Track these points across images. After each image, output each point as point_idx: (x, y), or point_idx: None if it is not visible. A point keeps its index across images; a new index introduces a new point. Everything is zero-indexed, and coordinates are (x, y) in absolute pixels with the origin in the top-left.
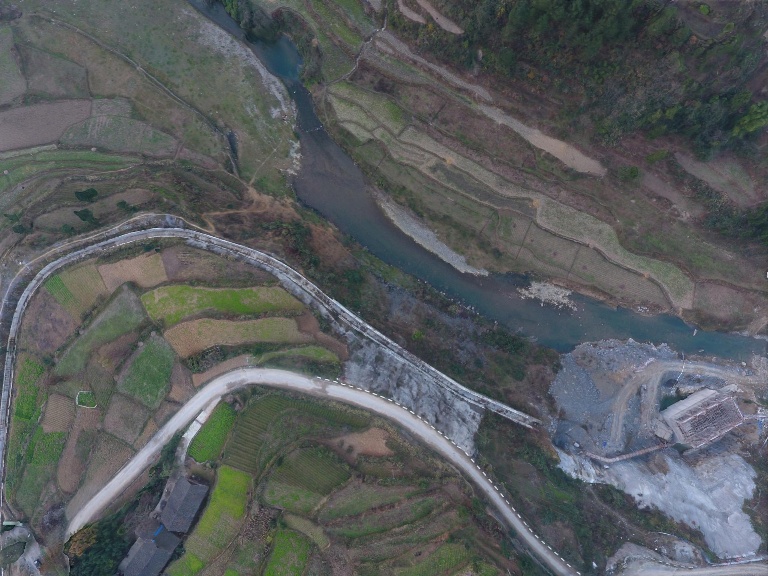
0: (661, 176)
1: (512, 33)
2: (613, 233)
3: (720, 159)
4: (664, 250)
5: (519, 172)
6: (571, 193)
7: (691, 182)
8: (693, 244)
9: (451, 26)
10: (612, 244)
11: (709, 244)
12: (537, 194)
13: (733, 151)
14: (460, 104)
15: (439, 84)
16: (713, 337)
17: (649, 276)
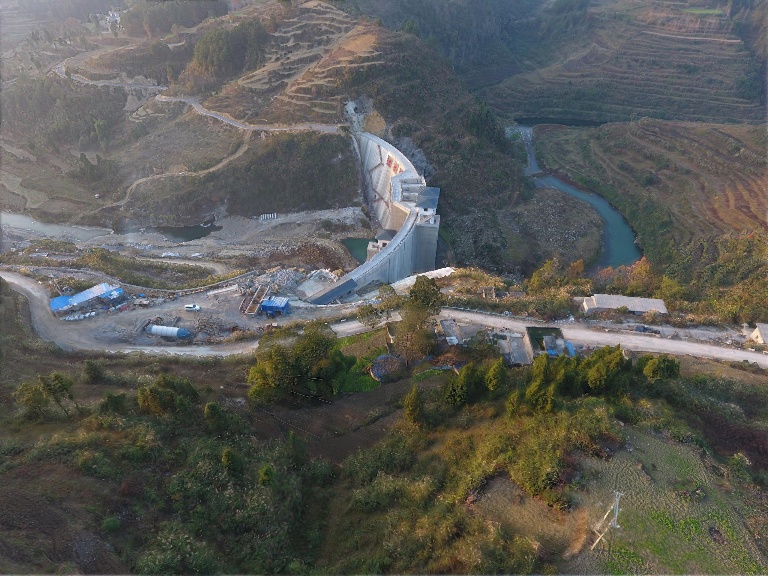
0: None
1: (11, 107)
2: None
3: (93, 151)
4: None
5: None
6: None
7: (71, 158)
8: (63, 185)
9: None
10: (15, 184)
11: (71, 185)
12: None
13: (99, 147)
14: None
15: None
16: (45, 226)
17: (23, 195)
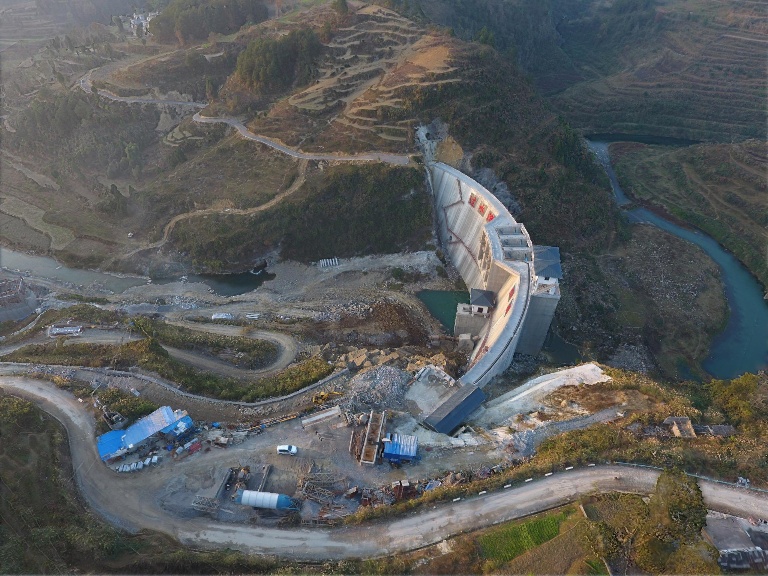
0: (88, 188)
1: (31, 126)
2: (43, 214)
3: (124, 179)
4: (68, 221)
5: (10, 188)
6: (33, 197)
7: None
8: (91, 220)
9: (12, 130)
10: None
11: (100, 220)
12: (12, 197)
13: (130, 174)
14: (4, 163)
15: (0, 157)
16: (72, 272)
17: (46, 233)
